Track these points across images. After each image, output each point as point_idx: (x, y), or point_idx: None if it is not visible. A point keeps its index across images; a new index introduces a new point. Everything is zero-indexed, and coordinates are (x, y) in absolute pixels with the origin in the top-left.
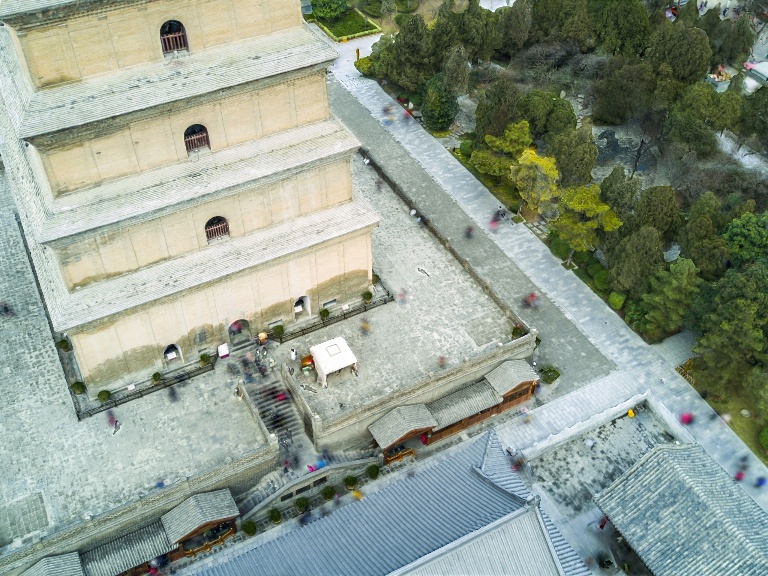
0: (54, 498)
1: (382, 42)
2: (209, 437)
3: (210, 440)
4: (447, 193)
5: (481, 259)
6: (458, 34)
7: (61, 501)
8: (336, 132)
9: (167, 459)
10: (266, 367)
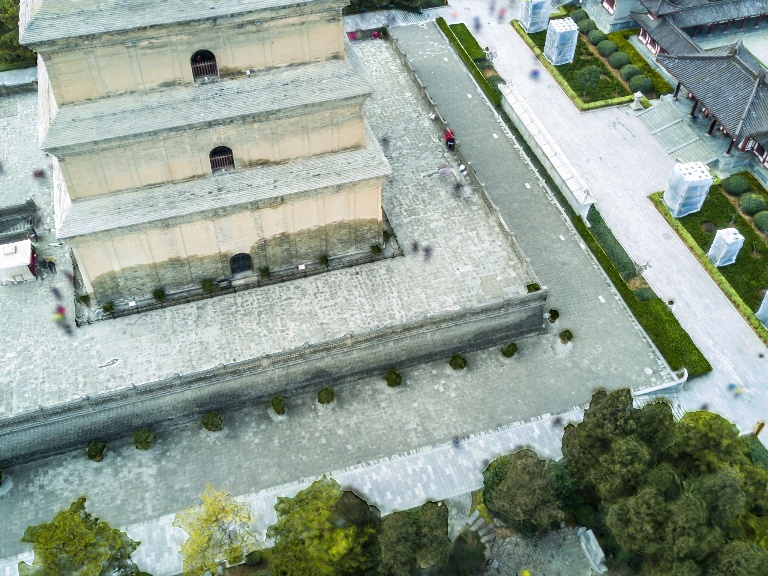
0: (8, 121)
1: (716, 424)
2: (4, 190)
3: (1, 191)
4: (324, 473)
5: (170, 478)
6: (624, 486)
7: (3, 124)
8: (50, 119)
9: (1, 169)
10: (53, 226)
